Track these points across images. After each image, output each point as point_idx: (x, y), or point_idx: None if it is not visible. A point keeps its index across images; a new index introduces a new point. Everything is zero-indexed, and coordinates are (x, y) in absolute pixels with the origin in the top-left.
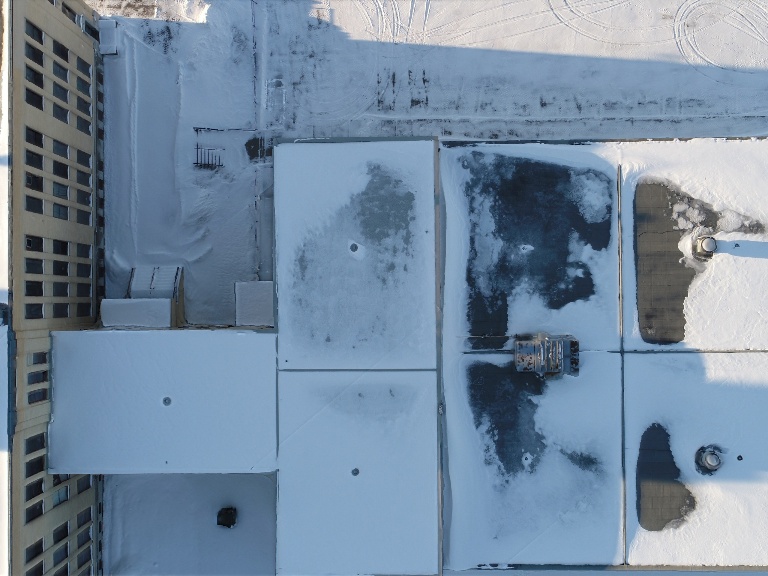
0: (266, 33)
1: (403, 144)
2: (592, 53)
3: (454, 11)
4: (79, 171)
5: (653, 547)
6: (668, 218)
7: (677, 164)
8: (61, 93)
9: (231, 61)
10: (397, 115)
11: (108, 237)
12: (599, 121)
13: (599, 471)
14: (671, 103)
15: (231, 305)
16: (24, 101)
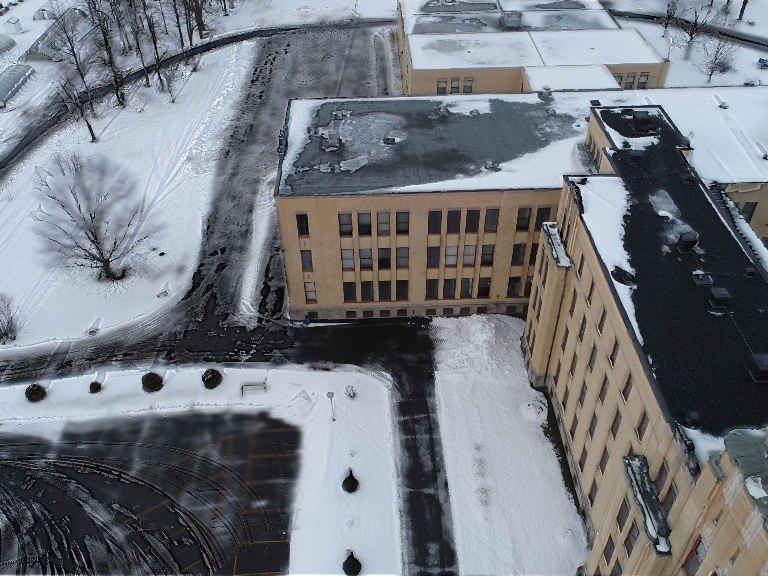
0: None
1: (411, 41)
2: (341, 73)
3: None
4: None
5: (593, 5)
6: None
7: None
8: None
9: None
10: None
11: None
12: None
13: (563, 15)
14: (368, 57)
15: None
16: None
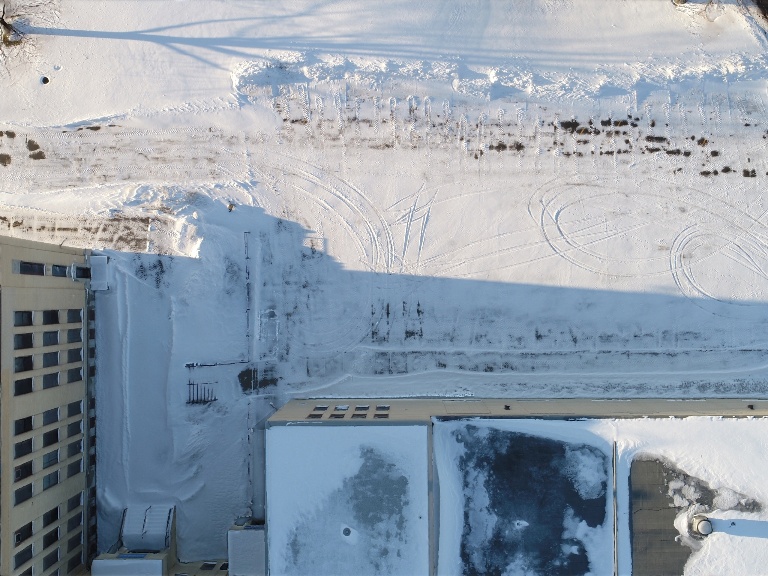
0: (259, 263)
1: (396, 429)
2: (588, 285)
3: (449, 241)
4: (70, 424)
5: None
6: (664, 495)
7: (673, 442)
8: (51, 357)
9: (224, 292)
10: (391, 347)
11: (100, 474)
12: (595, 354)
13: None
14: (667, 336)
15: (224, 539)
16: (13, 397)
